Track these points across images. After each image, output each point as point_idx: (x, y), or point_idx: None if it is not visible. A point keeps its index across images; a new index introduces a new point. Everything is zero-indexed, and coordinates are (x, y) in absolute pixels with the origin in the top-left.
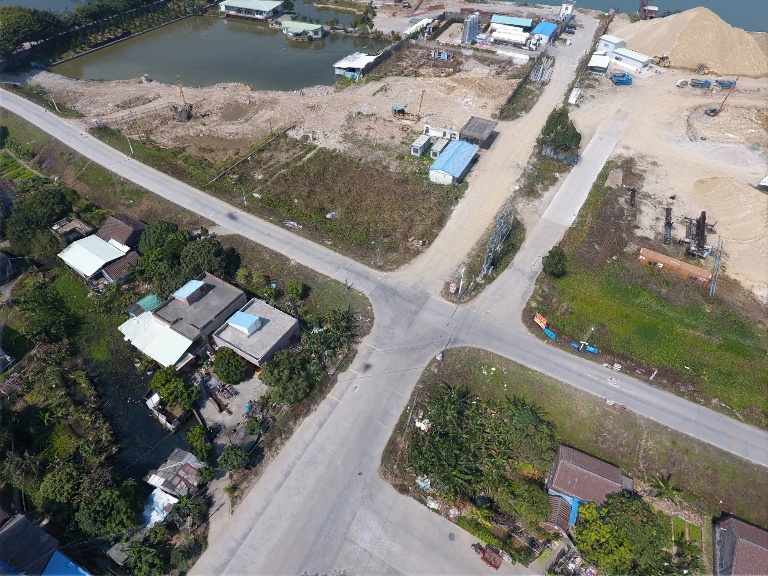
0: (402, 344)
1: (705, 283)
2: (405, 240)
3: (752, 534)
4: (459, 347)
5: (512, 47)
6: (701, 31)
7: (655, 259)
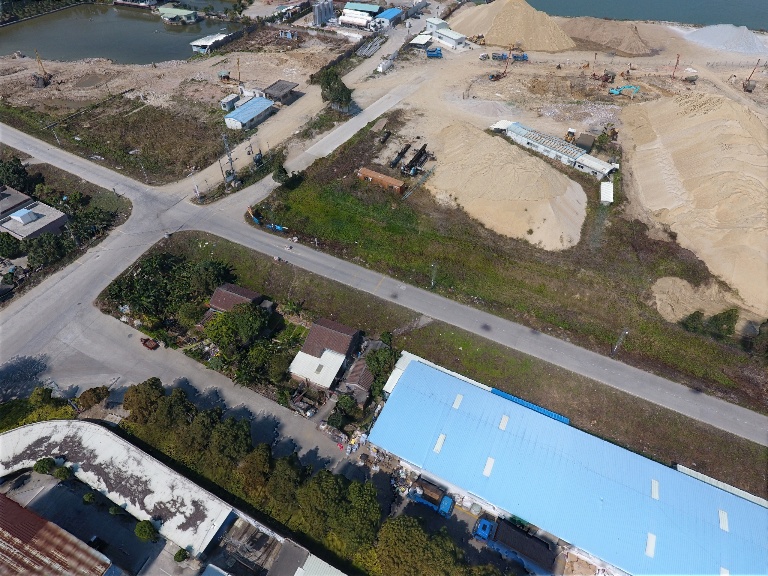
0: (145, 230)
1: (398, 190)
2: (184, 167)
3: (327, 323)
4: (186, 230)
5: (357, 29)
6: (512, 14)
7: (367, 175)
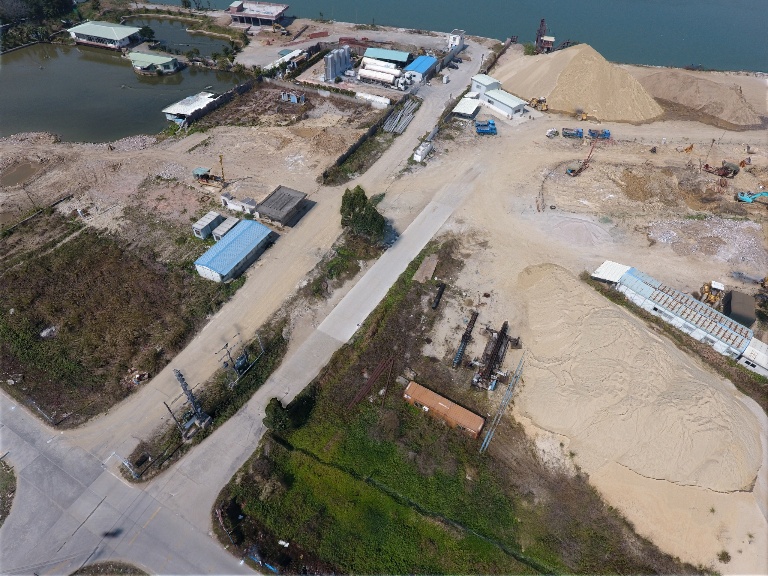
0: (26, 560)
1: (475, 435)
2: (123, 371)
3: None
4: (101, 564)
5: (380, 86)
6: (582, 71)
7: (420, 400)
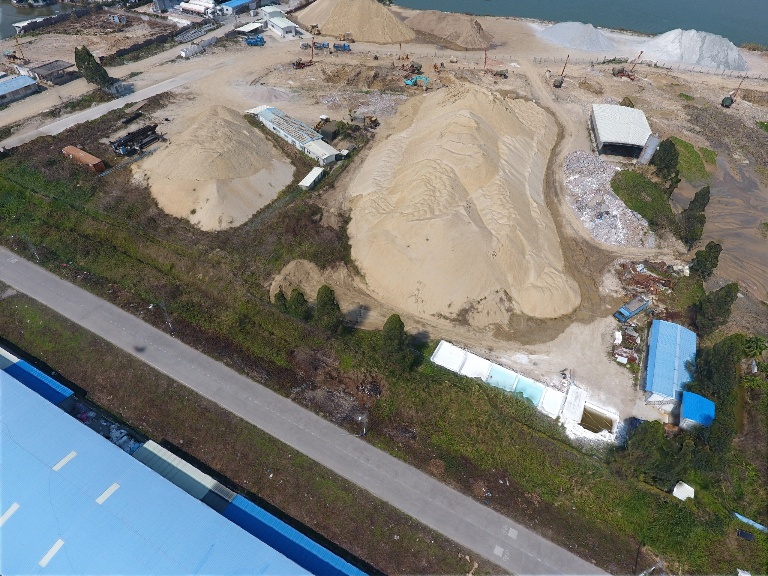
0: None
1: (93, 168)
2: None
3: None
4: None
5: (197, 16)
6: (349, 5)
7: (69, 152)
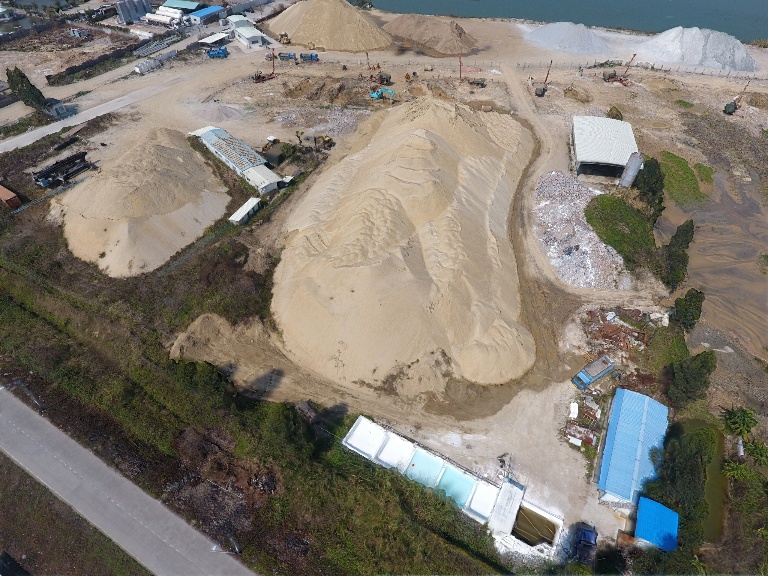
0: None
1: (7, 204)
2: None
3: None
4: None
5: (163, 27)
6: (320, 11)
7: None
